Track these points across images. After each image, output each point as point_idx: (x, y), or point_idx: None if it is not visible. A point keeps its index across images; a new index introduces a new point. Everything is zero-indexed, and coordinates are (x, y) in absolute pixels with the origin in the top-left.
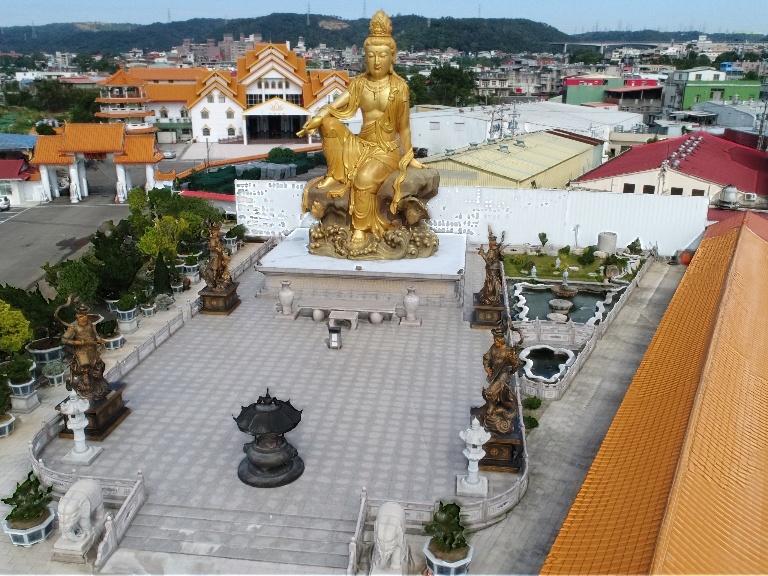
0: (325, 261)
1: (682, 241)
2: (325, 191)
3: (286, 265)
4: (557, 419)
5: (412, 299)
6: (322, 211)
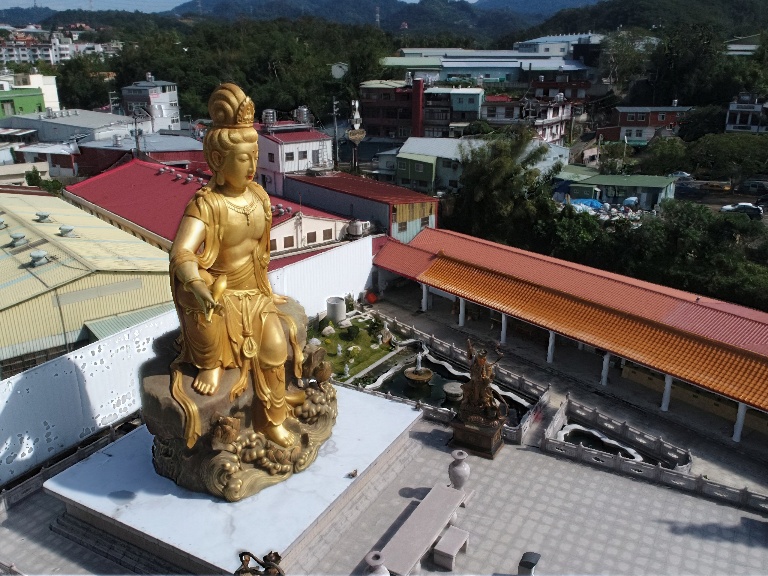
0: (288, 497)
1: (361, 283)
2: (226, 393)
3: (278, 541)
4: (729, 481)
5: (468, 467)
6: (239, 426)
